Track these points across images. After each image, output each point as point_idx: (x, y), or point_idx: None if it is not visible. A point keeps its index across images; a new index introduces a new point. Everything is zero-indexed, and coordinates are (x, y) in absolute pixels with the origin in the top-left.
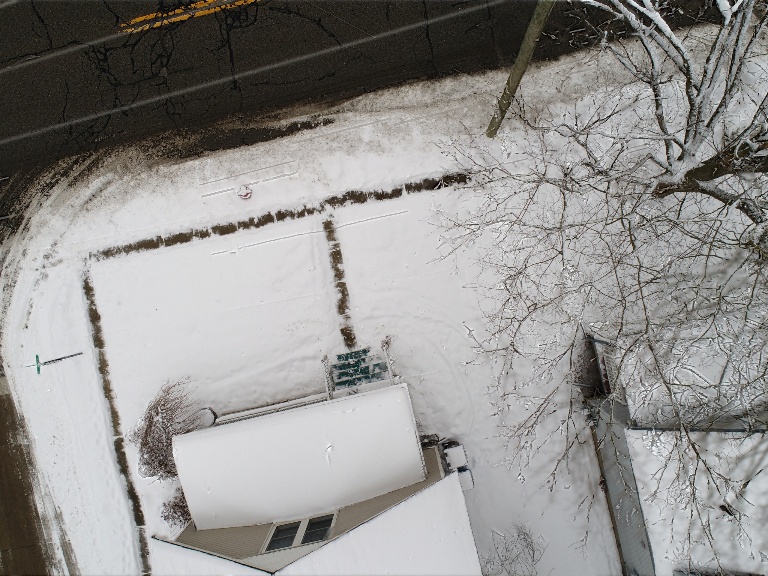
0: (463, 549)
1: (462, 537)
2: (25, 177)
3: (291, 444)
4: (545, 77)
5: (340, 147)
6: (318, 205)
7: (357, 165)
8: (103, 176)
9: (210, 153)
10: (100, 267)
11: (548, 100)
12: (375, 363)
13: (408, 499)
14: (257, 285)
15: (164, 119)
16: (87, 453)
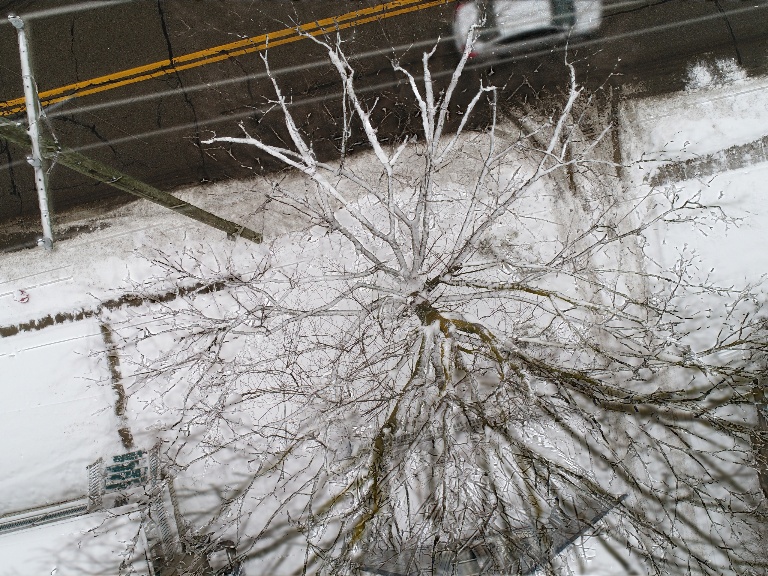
0: None
1: None
2: None
3: (18, 567)
4: (310, 184)
5: (113, 252)
6: (95, 308)
7: (131, 270)
8: None
9: None
10: None
11: None
12: (147, 465)
13: None
14: (34, 388)
15: None
16: None
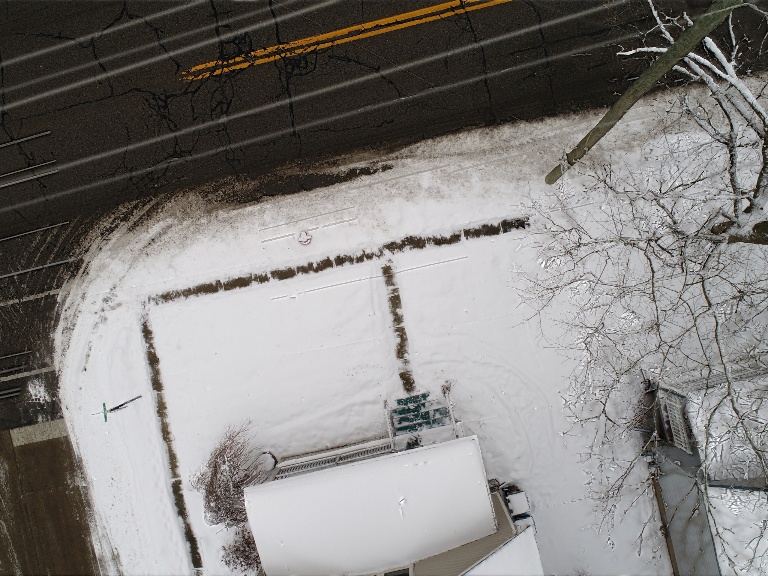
0: None
1: None
2: (85, 222)
3: (364, 497)
4: None
5: (399, 193)
6: (377, 250)
7: (416, 211)
8: (163, 221)
9: (269, 198)
10: (159, 311)
11: (607, 147)
12: (435, 408)
13: (489, 557)
14: (317, 330)
15: (223, 165)
16: (146, 496)
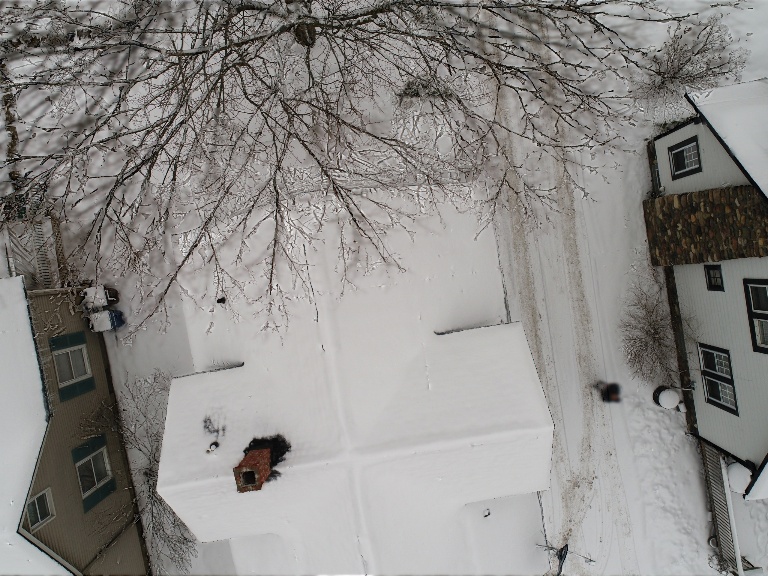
0: (14, 350)
1: (15, 339)
2: None
3: None
4: None
5: None
6: None
7: None
8: None
9: None
10: None
11: None
12: None
13: None
14: None
15: None
16: None
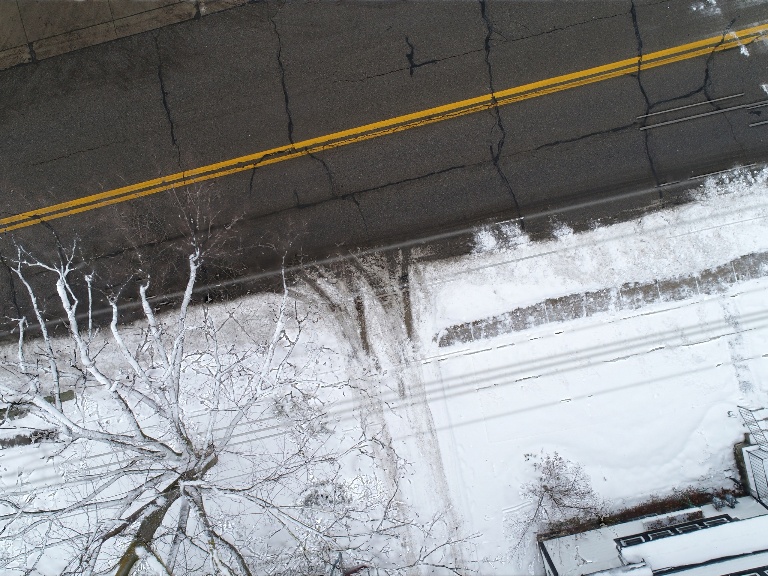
0: None
1: None
2: None
3: None
4: None
5: None
6: None
7: None
8: None
9: None
10: None
11: (119, 366)
12: None
13: None
14: None
15: None
16: None
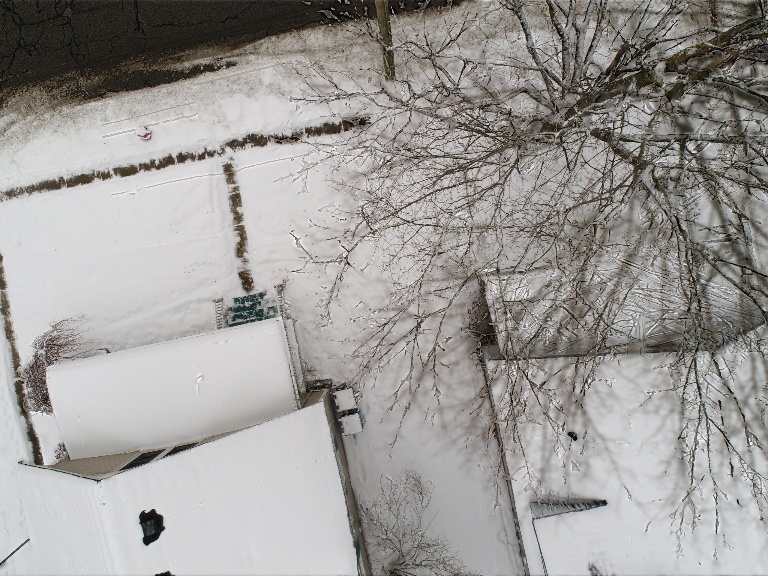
0: (325, 478)
1: (324, 467)
2: None
3: (162, 374)
4: None
5: (240, 89)
6: (219, 148)
7: (257, 108)
8: (7, 116)
9: (113, 94)
10: (2, 207)
11: None
12: (270, 306)
13: (263, 423)
14: (155, 226)
15: (68, 59)
16: None
